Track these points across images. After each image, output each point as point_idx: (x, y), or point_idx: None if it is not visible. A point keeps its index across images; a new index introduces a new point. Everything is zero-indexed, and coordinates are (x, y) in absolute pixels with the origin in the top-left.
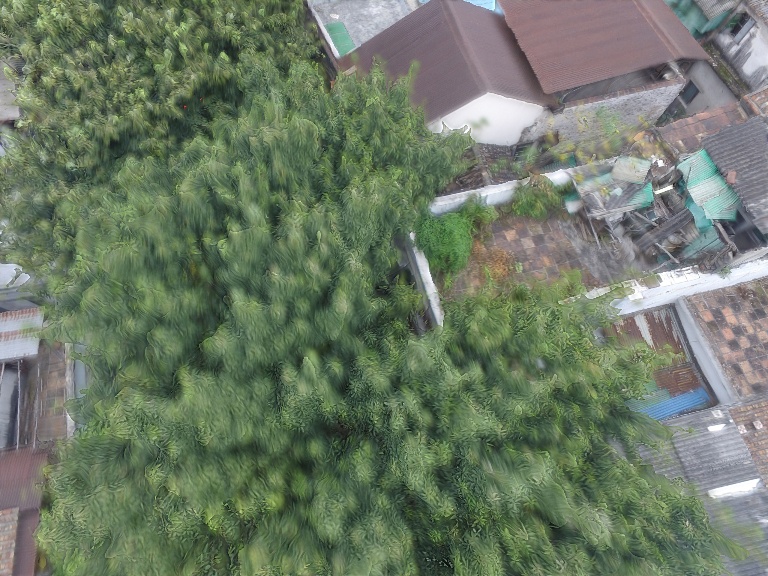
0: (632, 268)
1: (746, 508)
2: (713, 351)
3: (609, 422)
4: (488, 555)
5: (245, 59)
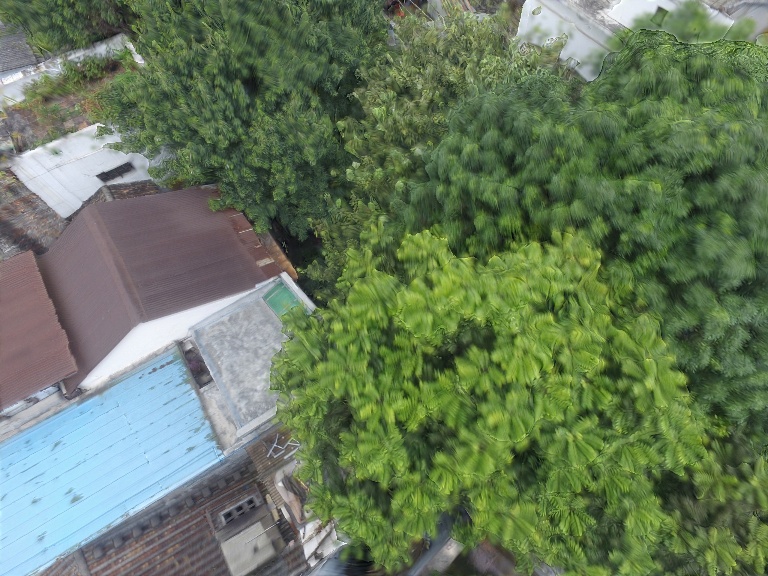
0: None
1: None
2: None
3: None
4: None
5: (318, 127)
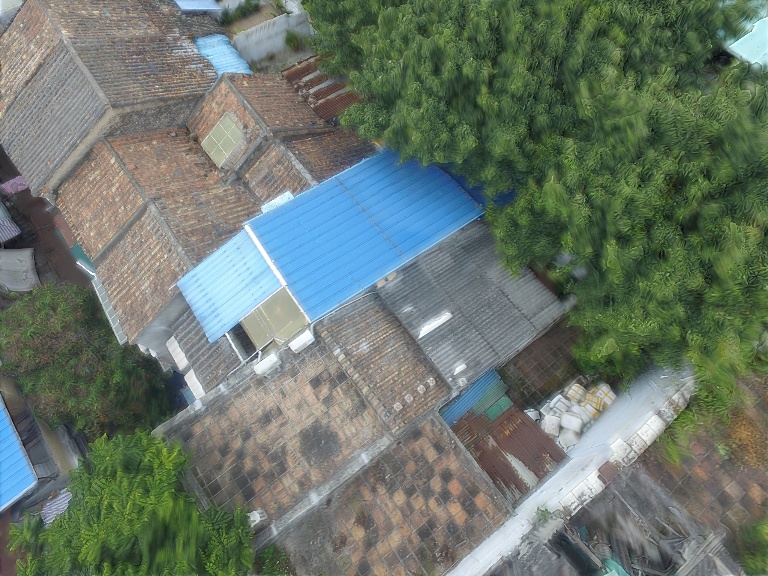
0: (611, 505)
1: (423, 314)
2: (469, 457)
3: (639, 267)
4: (735, 110)
5: None
